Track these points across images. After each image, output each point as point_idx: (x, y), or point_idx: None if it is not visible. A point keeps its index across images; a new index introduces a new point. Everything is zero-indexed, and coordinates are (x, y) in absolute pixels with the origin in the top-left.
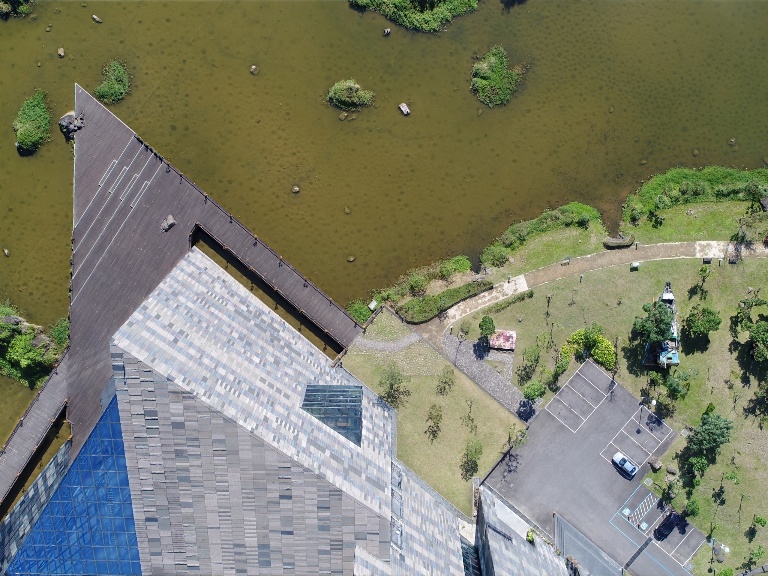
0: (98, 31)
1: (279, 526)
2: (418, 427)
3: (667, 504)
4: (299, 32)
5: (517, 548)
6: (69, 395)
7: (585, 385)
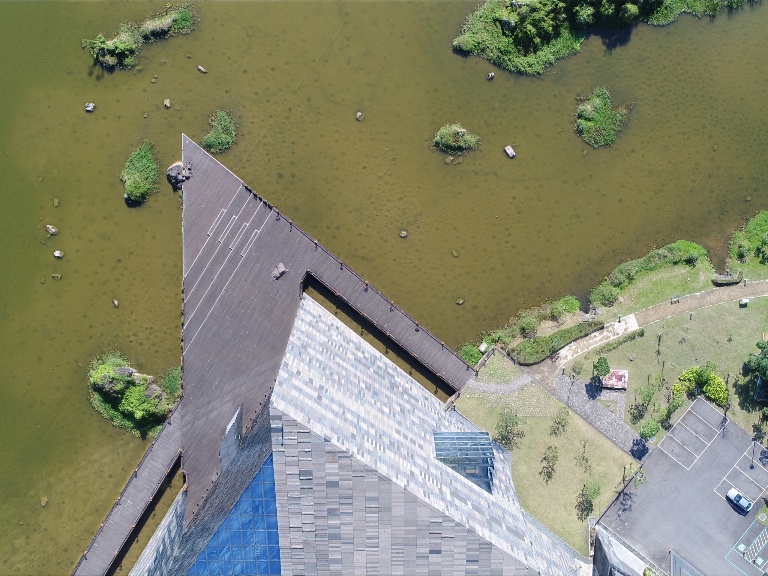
0: (203, 81)
1: None
2: (533, 468)
3: None
4: (403, 78)
5: None
6: (183, 445)
7: (697, 422)
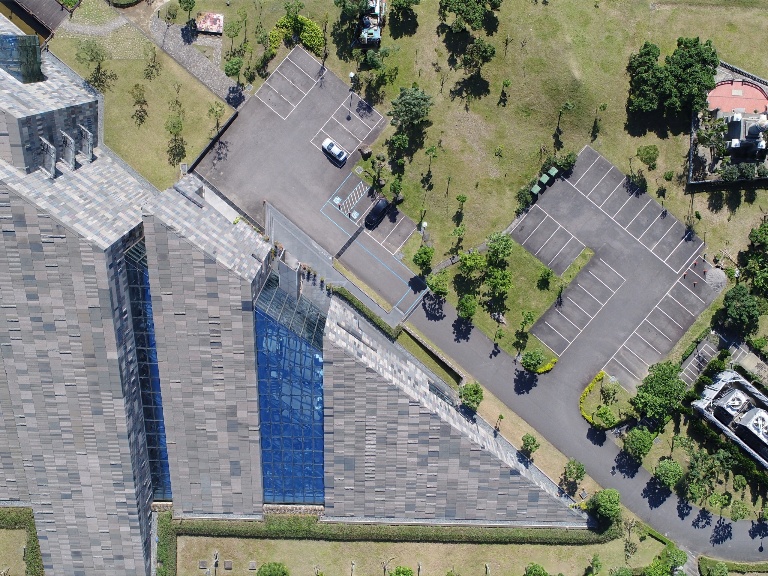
0: None
1: None
2: (125, 112)
3: (378, 192)
4: None
5: (204, 211)
6: None
7: (295, 71)
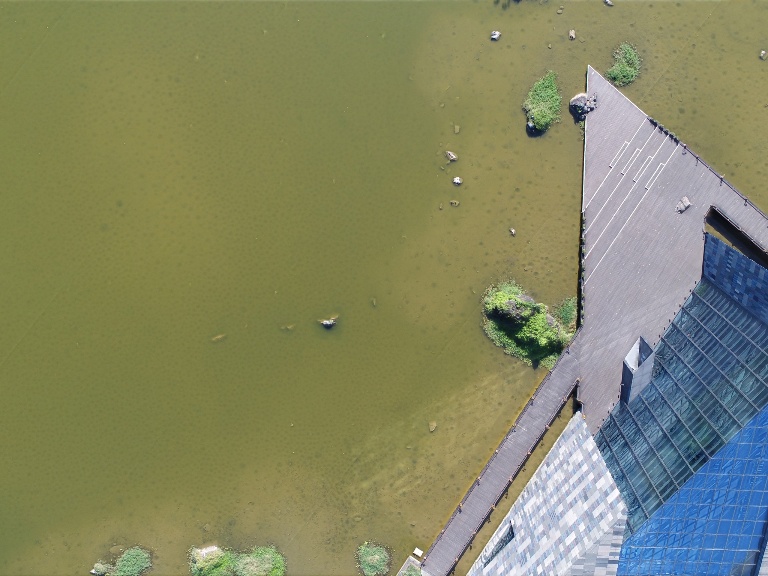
0: (609, 14)
1: None
2: None
3: None
4: None
5: None
6: (580, 374)
7: None
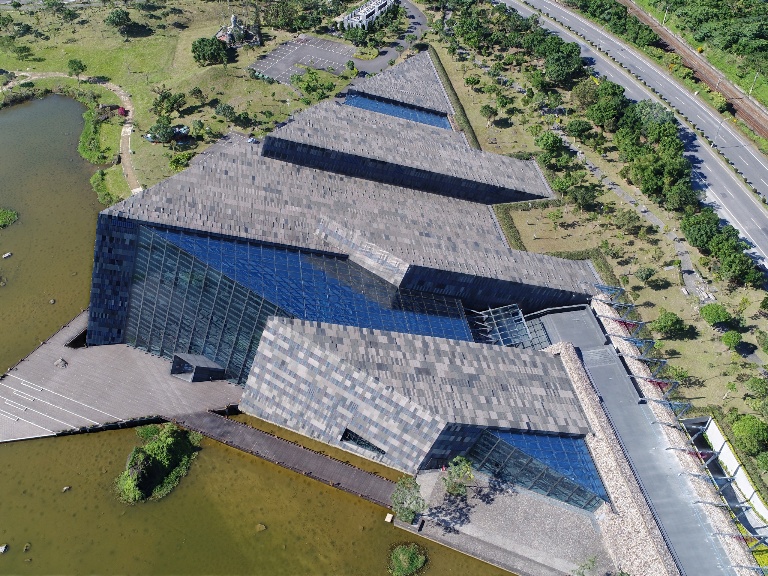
0: None
1: (249, 180)
2: None
3: None
4: None
5: None
6: (204, 411)
7: None
